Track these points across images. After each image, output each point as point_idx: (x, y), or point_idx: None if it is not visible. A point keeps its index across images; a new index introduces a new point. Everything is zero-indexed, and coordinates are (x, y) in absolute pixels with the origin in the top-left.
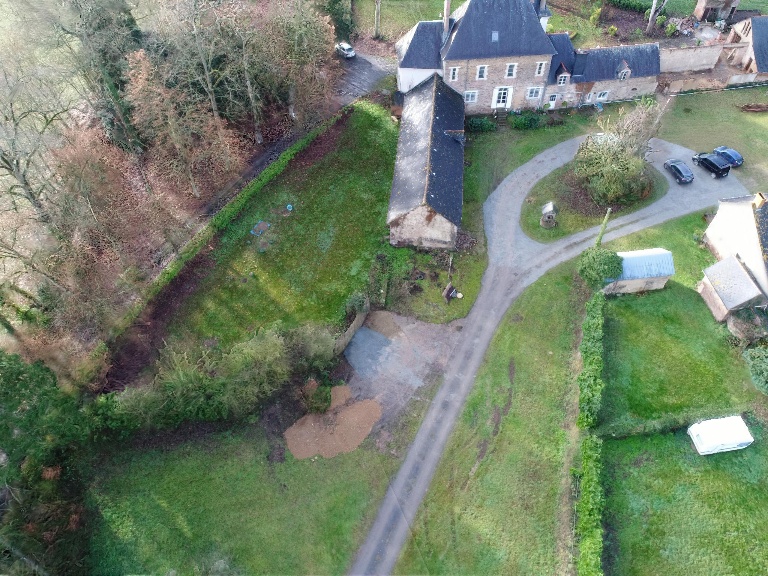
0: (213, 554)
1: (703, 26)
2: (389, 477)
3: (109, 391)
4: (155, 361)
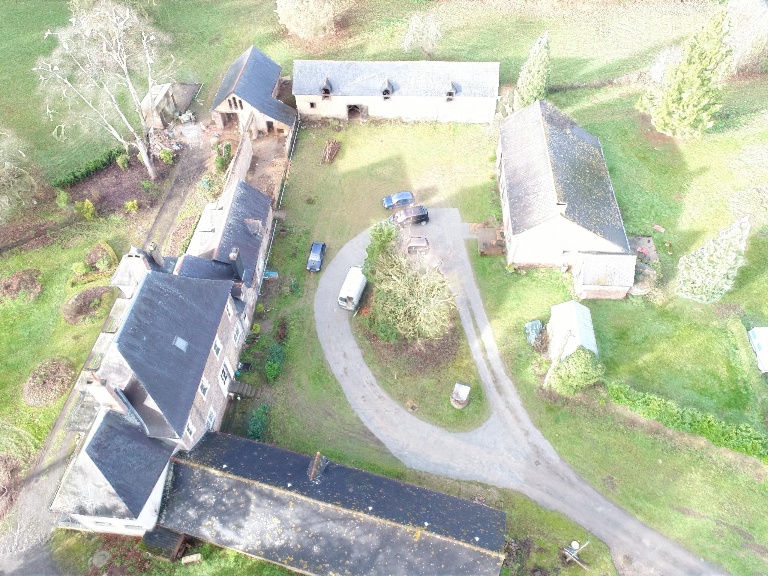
0: None
1: (174, 130)
2: None
3: None
4: None
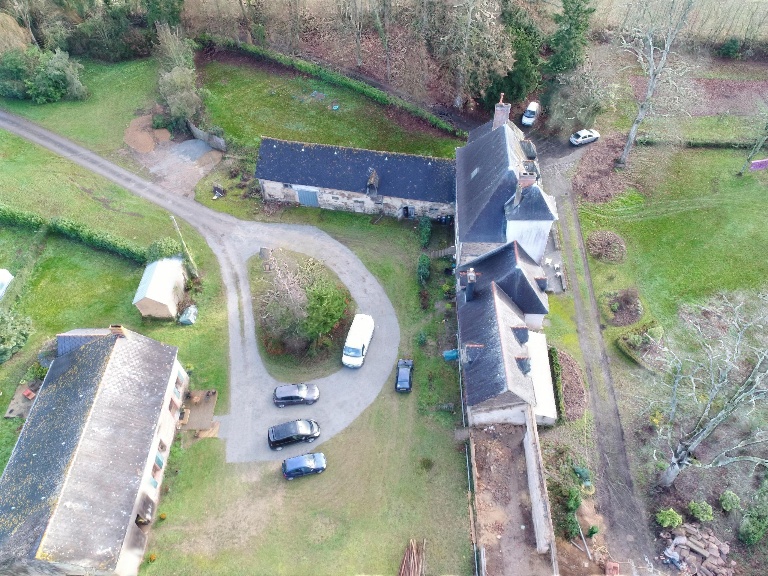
0: (99, 94)
1: None
2: (98, 152)
3: (209, 53)
4: (221, 64)
